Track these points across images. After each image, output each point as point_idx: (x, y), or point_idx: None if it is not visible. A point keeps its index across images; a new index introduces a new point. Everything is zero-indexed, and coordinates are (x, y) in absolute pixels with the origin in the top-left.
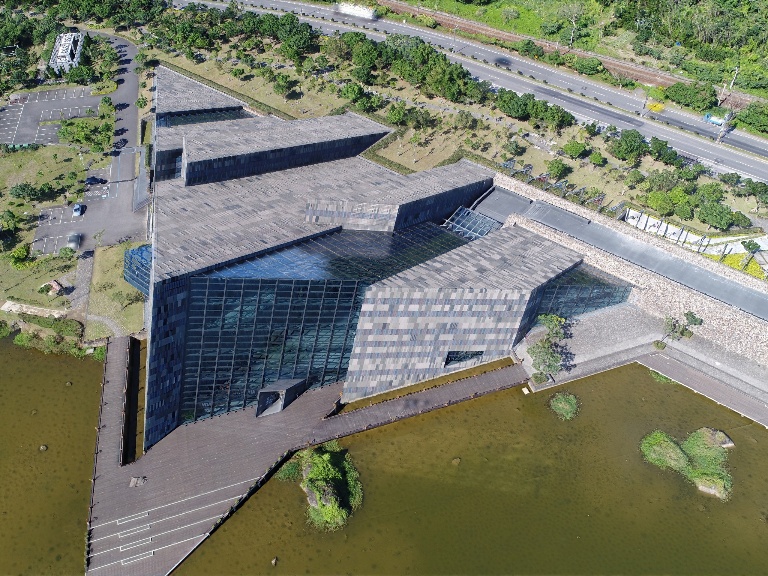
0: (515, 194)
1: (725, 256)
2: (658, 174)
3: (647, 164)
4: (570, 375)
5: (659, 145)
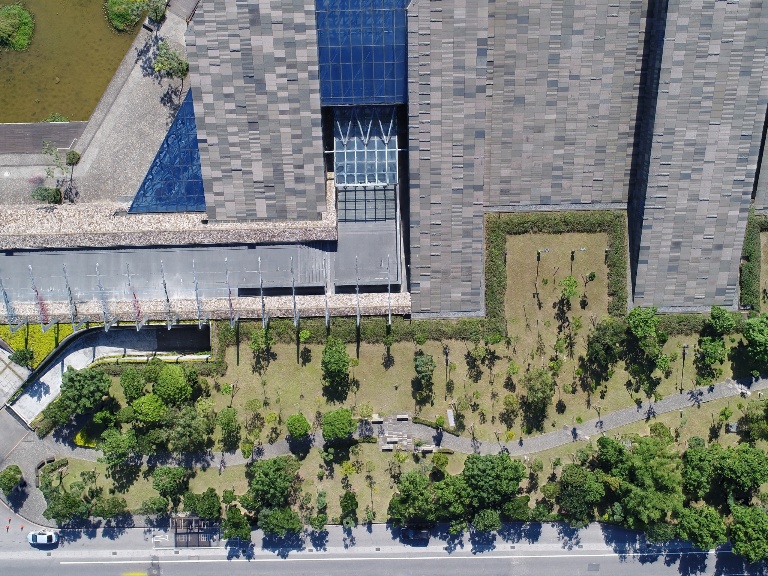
0: (363, 282)
1: (57, 340)
2: (191, 429)
3: (241, 488)
4: (135, 47)
5: (230, 516)
